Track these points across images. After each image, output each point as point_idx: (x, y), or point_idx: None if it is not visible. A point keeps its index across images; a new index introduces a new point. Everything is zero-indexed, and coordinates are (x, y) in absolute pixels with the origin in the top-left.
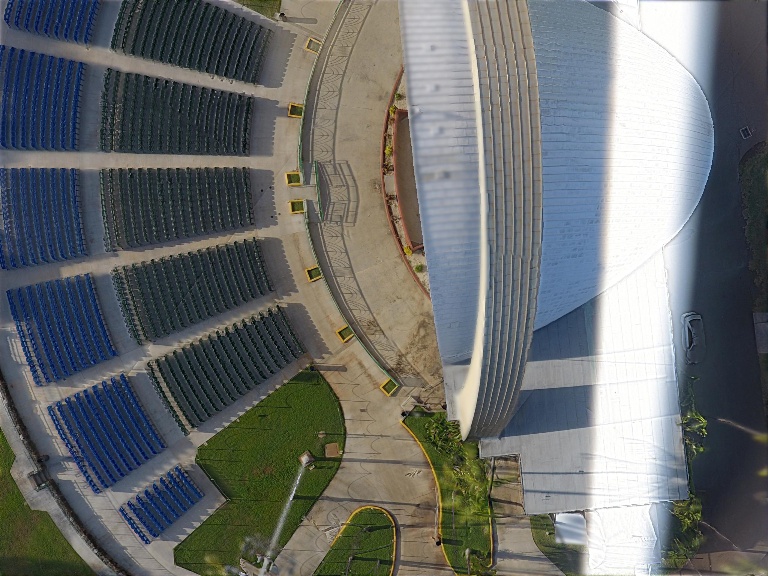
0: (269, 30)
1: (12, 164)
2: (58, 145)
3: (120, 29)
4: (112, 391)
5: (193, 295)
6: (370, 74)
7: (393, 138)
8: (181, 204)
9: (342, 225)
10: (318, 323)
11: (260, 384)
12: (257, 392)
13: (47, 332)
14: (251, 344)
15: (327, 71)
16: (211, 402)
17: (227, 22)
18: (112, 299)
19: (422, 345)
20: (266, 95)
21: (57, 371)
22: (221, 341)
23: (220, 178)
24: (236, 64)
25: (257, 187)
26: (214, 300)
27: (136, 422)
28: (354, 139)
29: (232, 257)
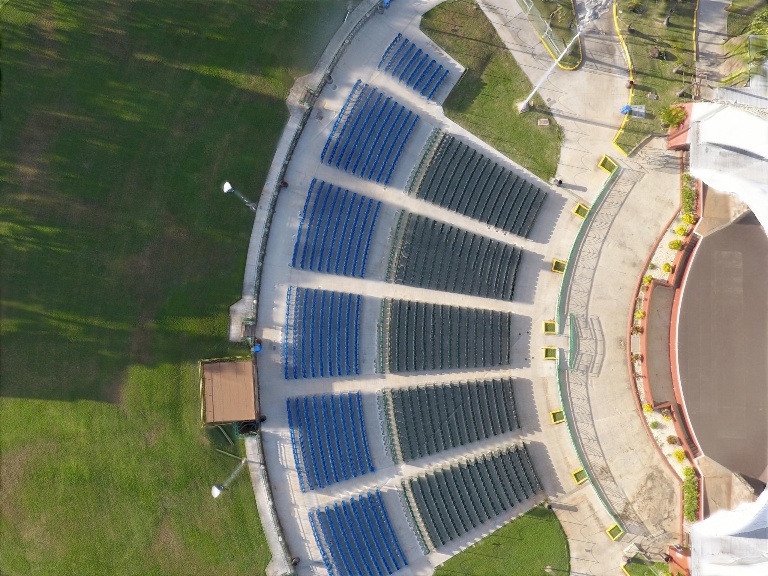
0: (546, 193)
1: (305, 283)
2: (349, 272)
3: (417, 176)
4: (367, 505)
5: (450, 424)
6: (628, 242)
7: (647, 305)
8: (449, 339)
9: (587, 375)
10: (556, 463)
11: (498, 514)
12: (494, 521)
13: (317, 442)
14: (496, 476)
15: (590, 234)
16: (454, 527)
17: (510, 182)
18: (375, 417)
19: (648, 496)
20: (534, 249)
21: (320, 480)
22: (470, 470)
23: (486, 319)
24: (514, 220)
25: (516, 330)
26: (468, 431)
27: (385, 537)
28: (607, 298)
29: (489, 393)
